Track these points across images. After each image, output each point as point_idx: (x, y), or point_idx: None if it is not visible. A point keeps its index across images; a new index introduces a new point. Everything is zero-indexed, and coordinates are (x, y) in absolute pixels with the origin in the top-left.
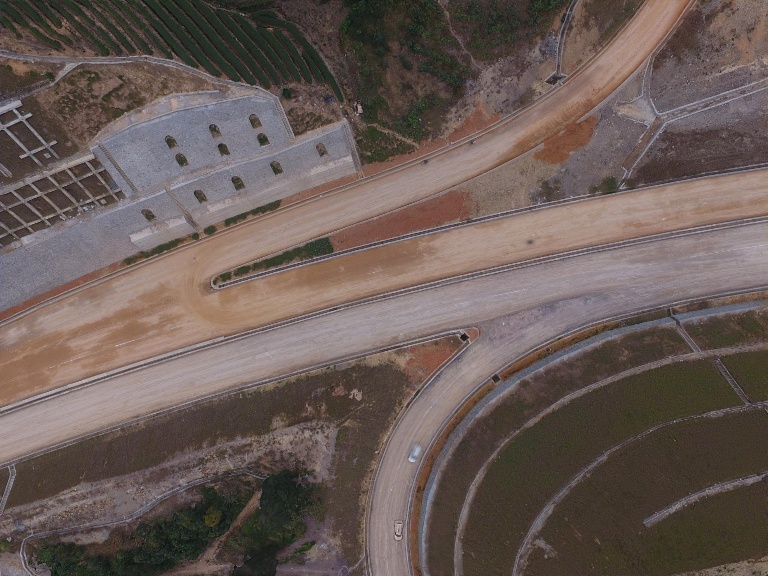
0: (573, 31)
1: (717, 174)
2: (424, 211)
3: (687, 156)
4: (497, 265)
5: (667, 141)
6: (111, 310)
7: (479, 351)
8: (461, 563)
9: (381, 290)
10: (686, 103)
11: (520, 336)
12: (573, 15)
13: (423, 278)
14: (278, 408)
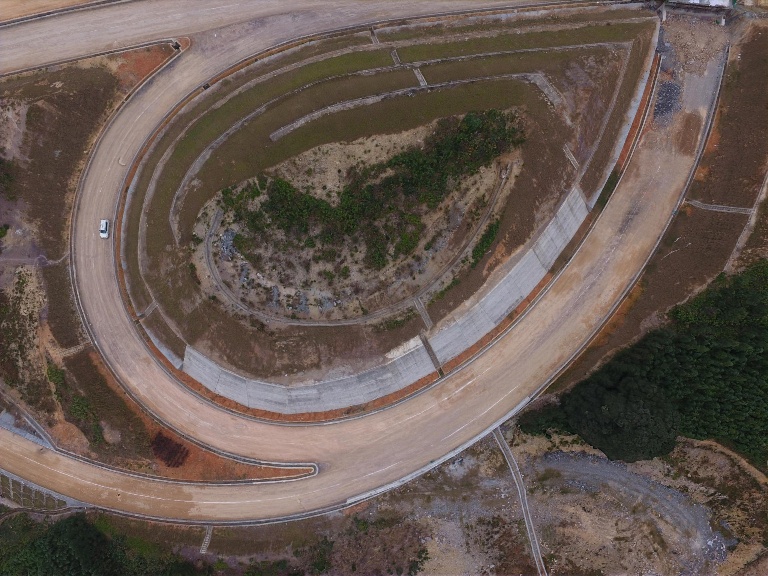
0: None
1: None
2: None
3: None
4: None
5: None
6: None
7: (191, 60)
8: (145, 235)
9: None
10: None
11: (231, 48)
12: None
13: None
14: None
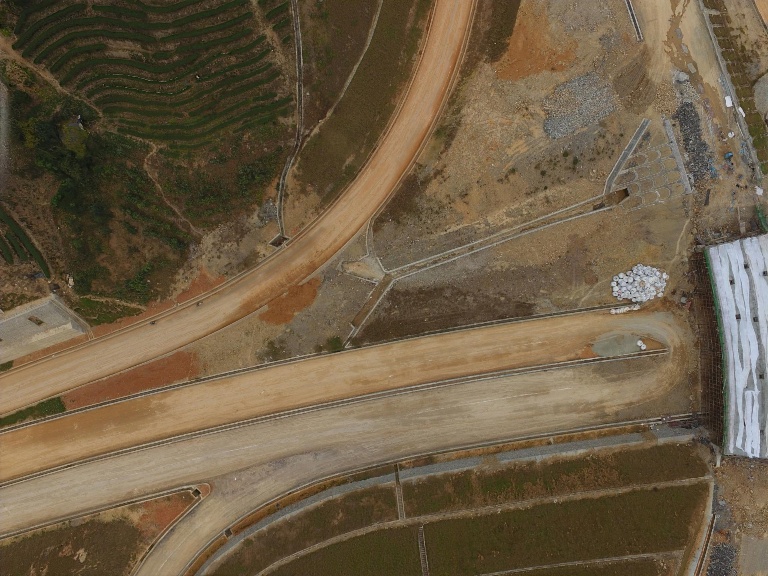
0: (289, 198)
1: (440, 333)
2: (153, 371)
3: (411, 315)
4: (227, 422)
5: (390, 301)
6: None
7: (212, 506)
8: None
9: (115, 447)
10: (413, 261)
11: (252, 491)
12: (286, 184)
13: (156, 435)
14: (7, 568)
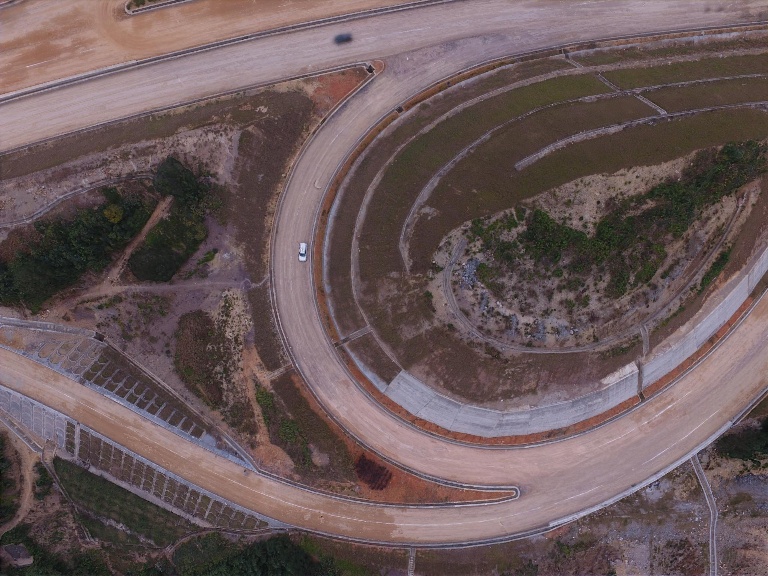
0: None
1: None
2: None
3: None
4: (402, 3)
5: None
6: (23, 31)
7: (384, 84)
8: (357, 260)
9: (291, 22)
10: None
11: (423, 71)
12: None
13: (332, 13)
14: (185, 122)
